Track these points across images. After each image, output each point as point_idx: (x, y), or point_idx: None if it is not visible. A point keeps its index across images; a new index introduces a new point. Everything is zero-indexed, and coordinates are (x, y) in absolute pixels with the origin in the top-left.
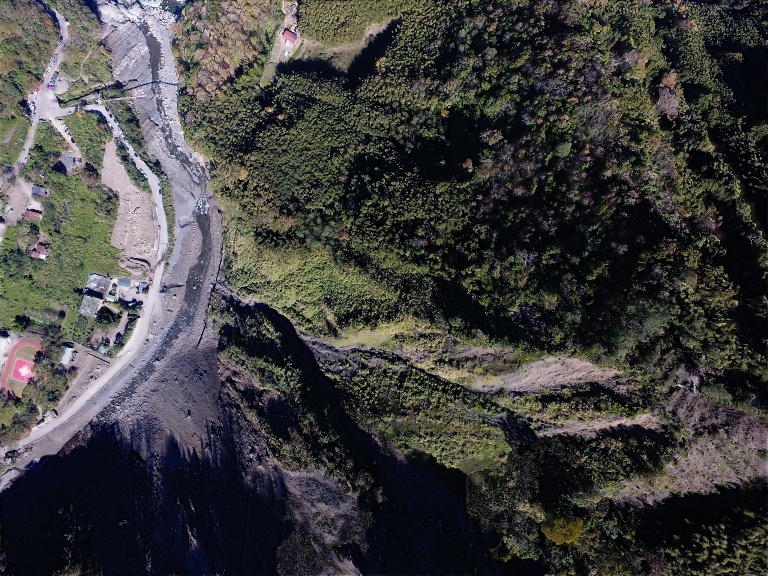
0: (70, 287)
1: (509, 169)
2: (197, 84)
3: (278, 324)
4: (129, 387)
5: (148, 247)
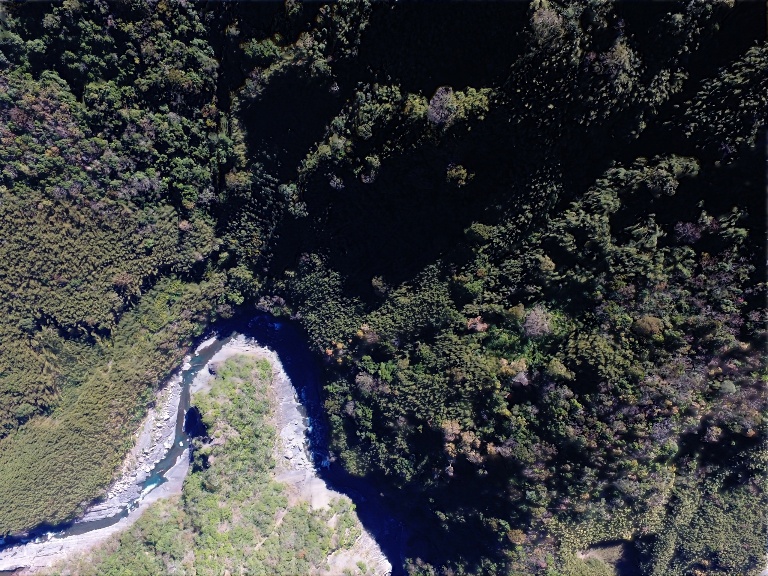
0: None
1: None
2: None
3: None
4: None
5: None
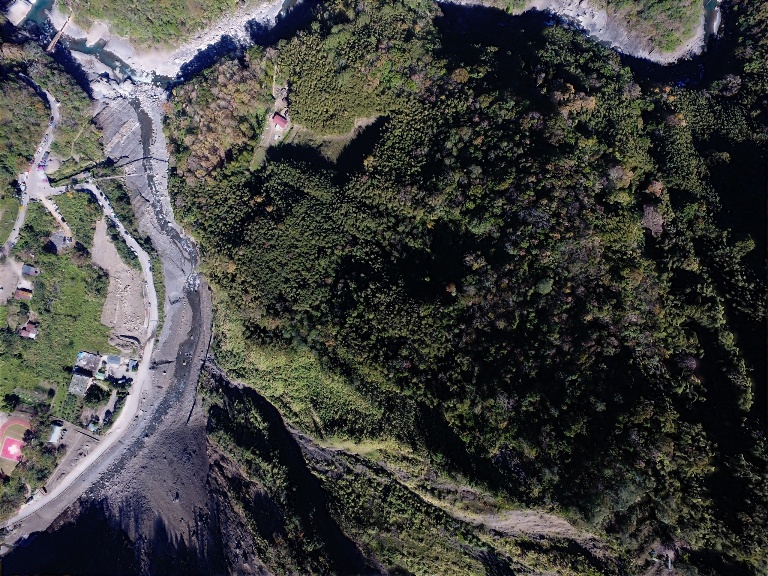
0: (60, 366)
1: (492, 299)
2: (187, 169)
3: (266, 413)
4: (118, 463)
5: (138, 325)
